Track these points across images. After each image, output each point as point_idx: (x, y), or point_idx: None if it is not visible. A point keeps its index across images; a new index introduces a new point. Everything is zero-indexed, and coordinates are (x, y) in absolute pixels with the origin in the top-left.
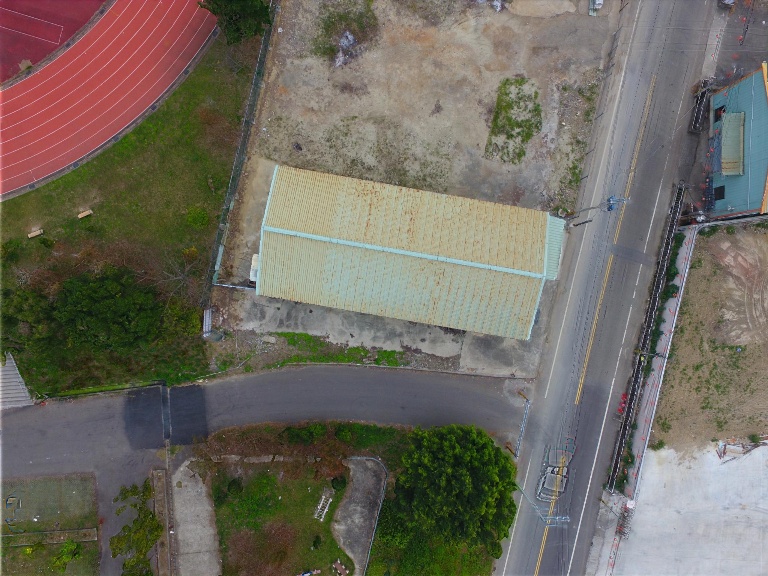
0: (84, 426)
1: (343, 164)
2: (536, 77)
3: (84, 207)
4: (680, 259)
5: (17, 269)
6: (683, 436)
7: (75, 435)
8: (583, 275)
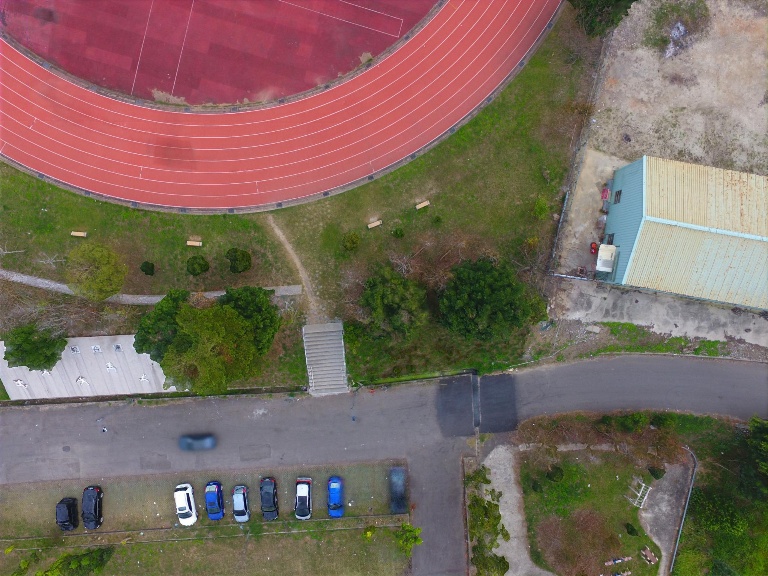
0: (397, 413)
1: (671, 155)
2: None
3: (420, 198)
4: None
5: (391, 258)
6: None
7: (389, 422)
8: None
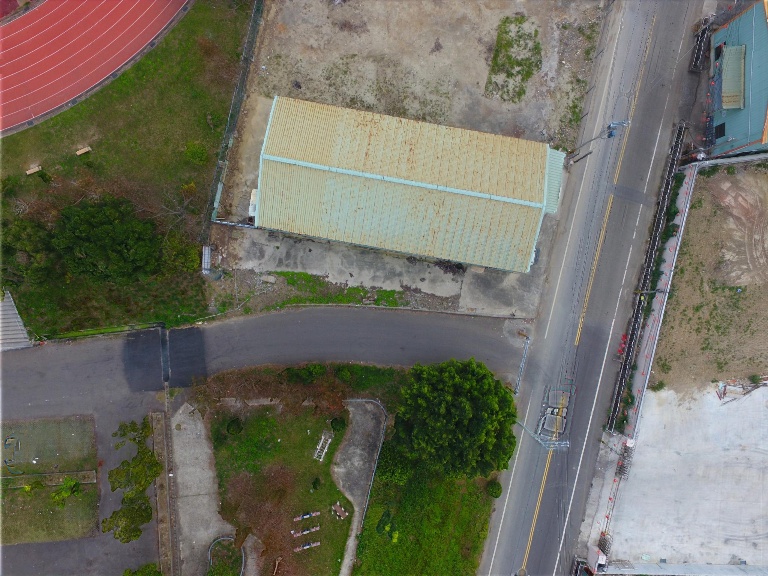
0: (83, 368)
1: (342, 102)
2: (536, 15)
3: (83, 144)
4: (680, 199)
5: (15, 199)
6: (683, 377)
7: (74, 377)
8: (583, 215)
